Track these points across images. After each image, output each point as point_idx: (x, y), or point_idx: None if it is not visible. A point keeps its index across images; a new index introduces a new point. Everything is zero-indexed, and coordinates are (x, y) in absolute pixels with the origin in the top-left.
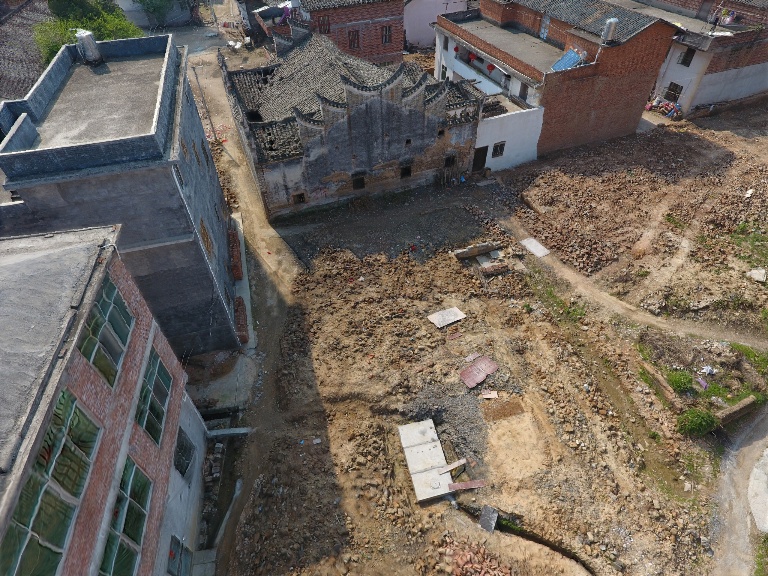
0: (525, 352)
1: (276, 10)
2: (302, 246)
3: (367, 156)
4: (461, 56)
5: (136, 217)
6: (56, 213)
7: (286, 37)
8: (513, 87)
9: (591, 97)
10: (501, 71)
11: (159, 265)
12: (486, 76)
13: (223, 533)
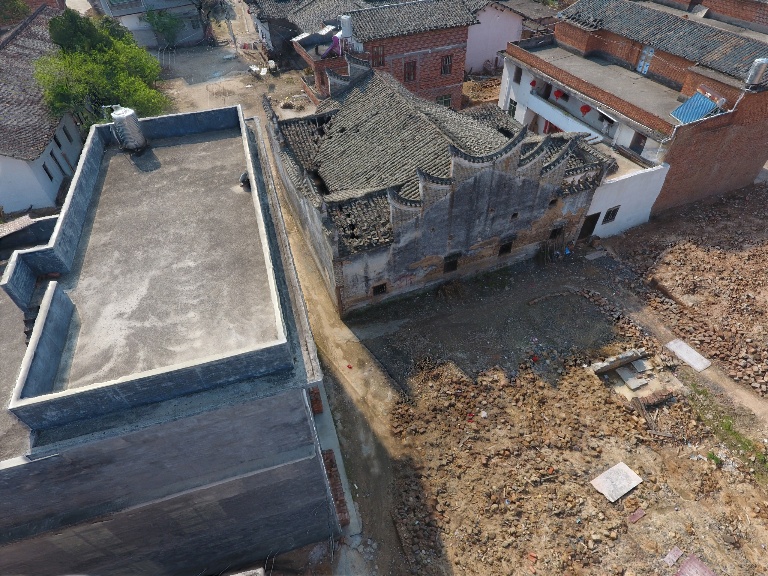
0: (741, 543)
1: (317, 37)
2: (390, 356)
3: (465, 235)
4: (537, 91)
5: (235, 440)
6: (111, 457)
7: (342, 76)
8: (621, 136)
9: (719, 149)
10: (597, 113)
11: (256, 482)
12: (577, 118)
13: None
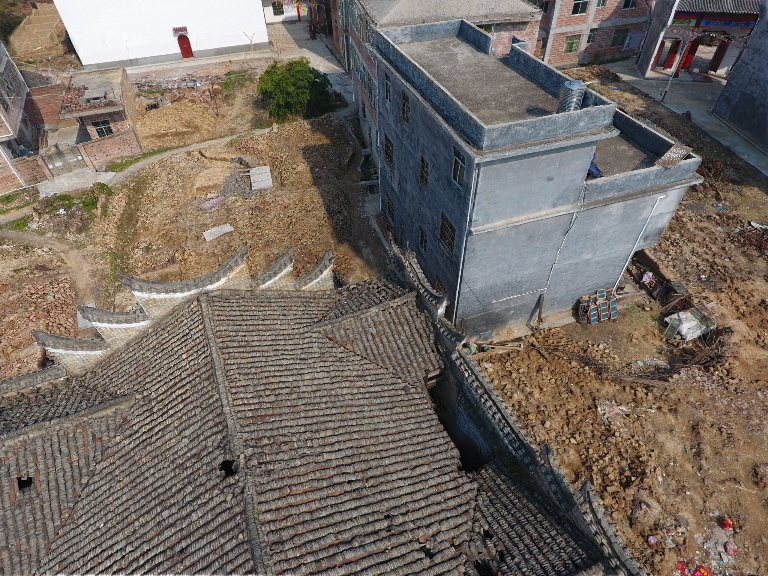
0: None
1: None
2: None
3: None
4: None
5: None
6: None
7: None
8: None
9: None
10: None
11: None
12: None
13: (362, 159)
